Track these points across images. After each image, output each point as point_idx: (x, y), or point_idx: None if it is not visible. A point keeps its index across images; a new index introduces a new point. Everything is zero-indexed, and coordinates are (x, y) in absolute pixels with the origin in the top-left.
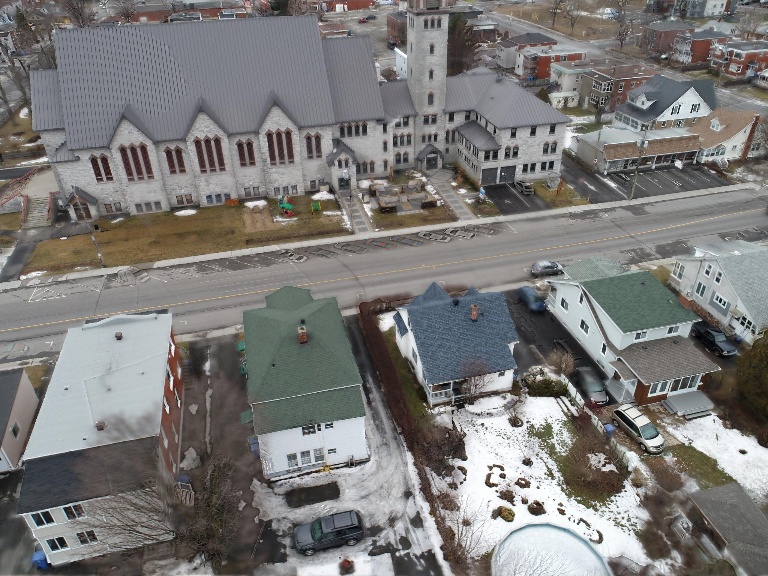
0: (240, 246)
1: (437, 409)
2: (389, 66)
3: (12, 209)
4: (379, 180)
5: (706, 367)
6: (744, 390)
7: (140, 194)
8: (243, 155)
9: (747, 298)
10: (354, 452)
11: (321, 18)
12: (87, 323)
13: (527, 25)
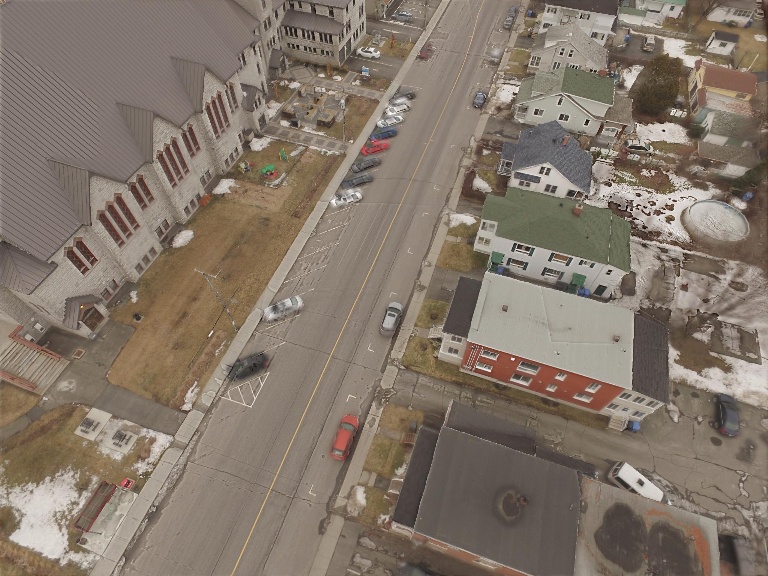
0: (298, 223)
1: None
2: None
3: None
4: (268, 104)
5: (630, 102)
6: (646, 103)
7: (134, 253)
8: (188, 145)
9: (591, 58)
10: None
11: None
12: (453, 330)
13: None
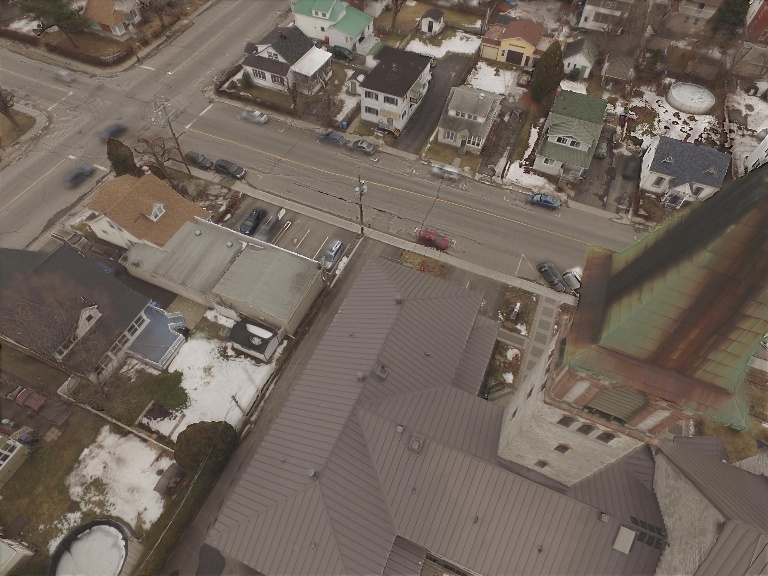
0: None
1: None
2: None
3: None
4: None
5: None
6: None
7: None
8: None
9: None
10: None
11: None
12: None
13: None
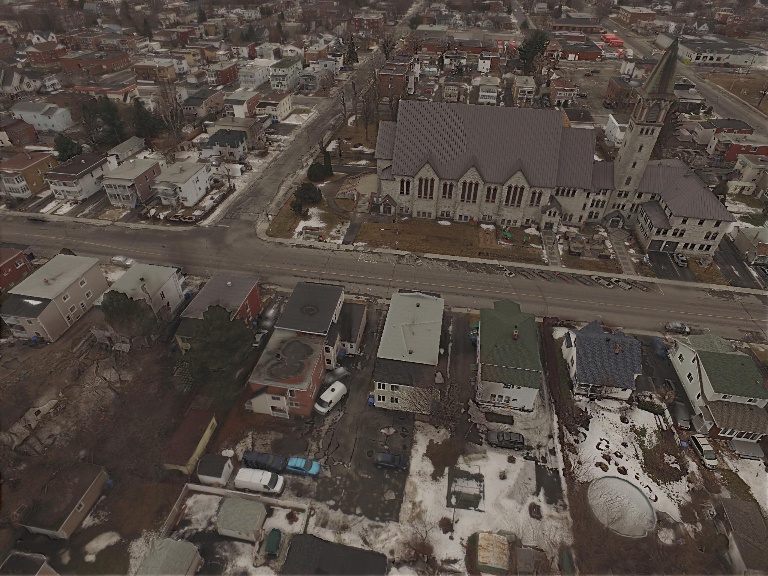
0: (475, 255)
1: (578, 396)
2: (600, 124)
3: (349, 197)
4: (573, 228)
5: (767, 431)
6: None
7: (422, 206)
8: (489, 195)
9: None
10: (526, 404)
11: (555, 66)
12: (400, 291)
13: (734, 99)
